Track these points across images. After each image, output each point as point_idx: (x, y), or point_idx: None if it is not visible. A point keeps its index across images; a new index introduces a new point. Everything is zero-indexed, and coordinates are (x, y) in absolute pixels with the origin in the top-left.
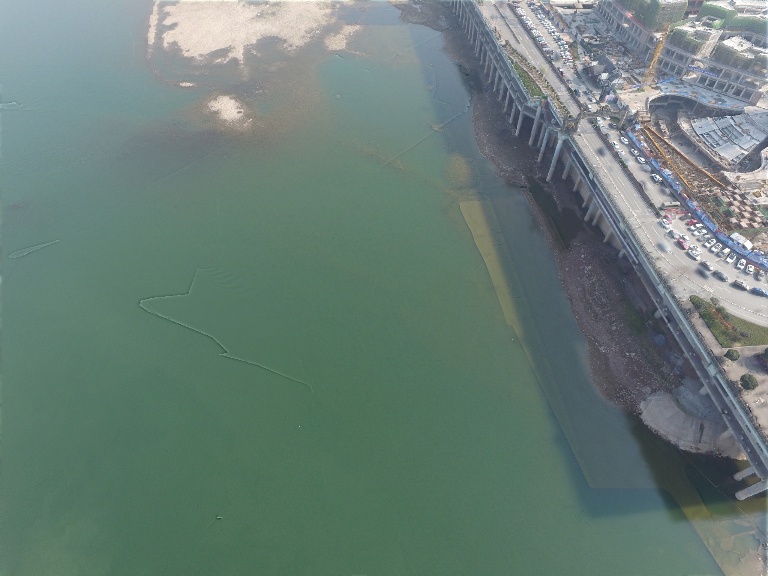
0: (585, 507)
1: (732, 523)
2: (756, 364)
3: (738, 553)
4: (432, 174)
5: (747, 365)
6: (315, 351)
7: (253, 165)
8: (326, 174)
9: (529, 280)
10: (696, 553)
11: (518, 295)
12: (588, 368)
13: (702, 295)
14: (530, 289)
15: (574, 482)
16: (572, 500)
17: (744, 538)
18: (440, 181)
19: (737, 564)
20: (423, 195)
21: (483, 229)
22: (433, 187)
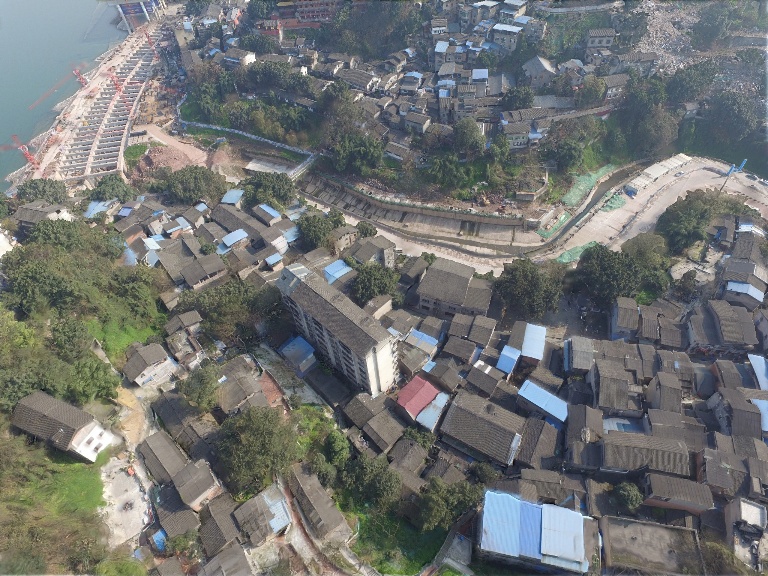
0: (77, 41)
1: None
2: None
3: None
4: None
5: None
6: (3, 18)
7: None
8: None
9: (112, 6)
10: None
11: (103, 9)
12: (110, 20)
13: None
14: (109, 8)
15: None
16: None
17: (123, 41)
18: None
19: (115, 44)
20: None
21: None
22: None
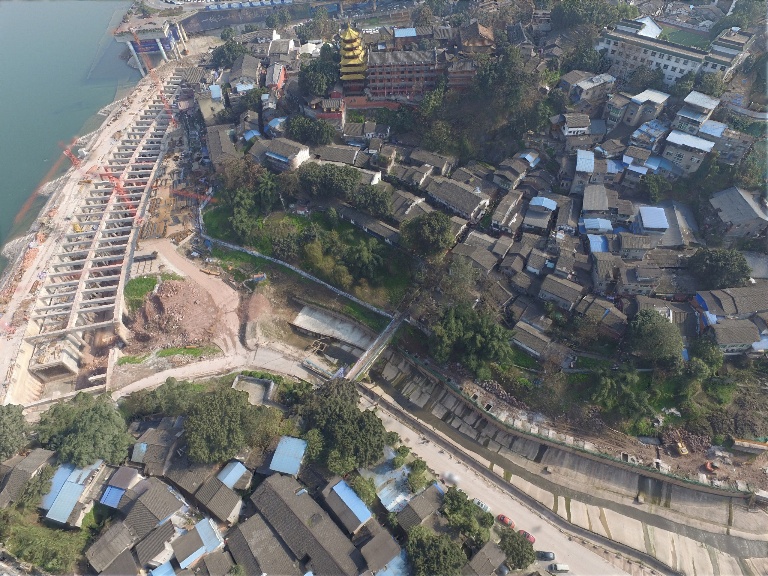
0: (79, 82)
1: (134, 82)
2: (140, 16)
3: (127, 87)
4: (113, 3)
5: (137, 17)
6: None
7: (18, 4)
8: (55, 5)
9: None
10: (113, 89)
11: None
12: (120, 52)
13: (147, 4)
14: None
15: (81, 77)
16: (76, 81)
17: (134, 85)
18: (114, 4)
19: (124, 89)
20: (101, 10)
21: (118, 18)
22: (108, 6)
